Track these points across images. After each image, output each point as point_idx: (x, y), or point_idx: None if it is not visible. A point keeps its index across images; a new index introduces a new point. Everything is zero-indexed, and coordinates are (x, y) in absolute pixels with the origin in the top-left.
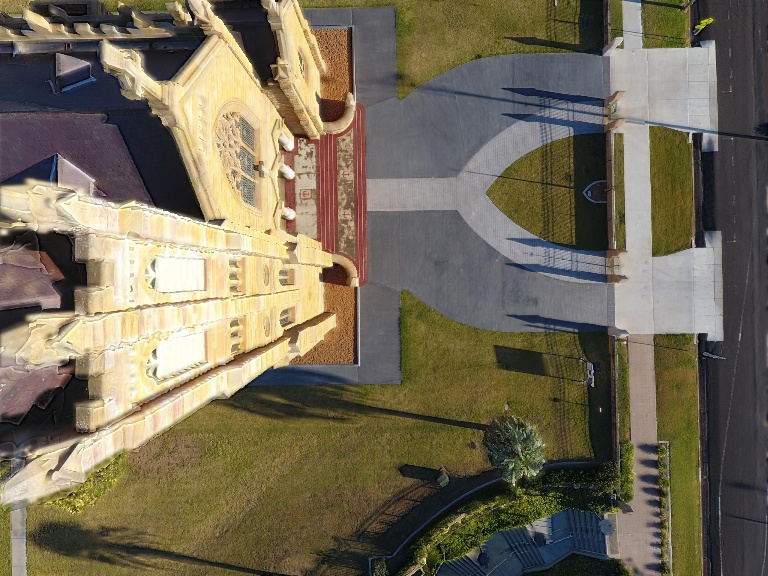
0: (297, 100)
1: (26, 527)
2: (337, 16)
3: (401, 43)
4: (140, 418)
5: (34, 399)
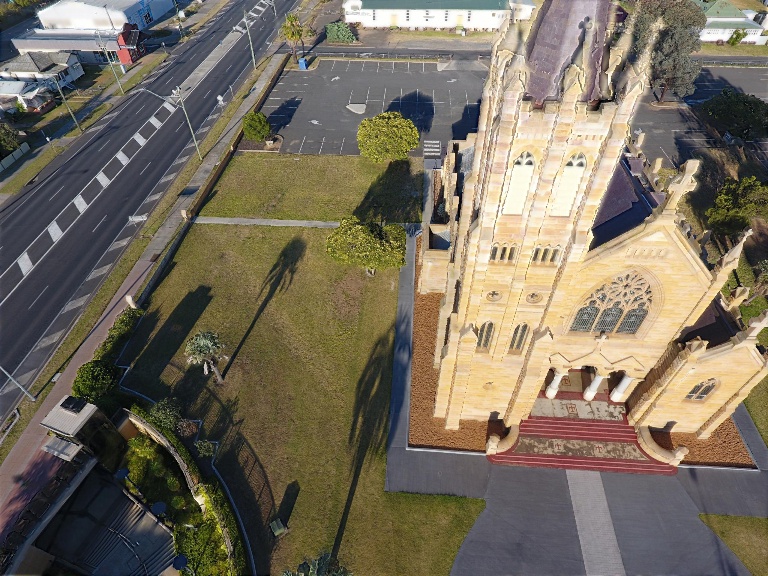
0: (670, 375)
1: (312, 227)
2: (762, 455)
3: (766, 524)
4: (513, 133)
5: (531, 93)
